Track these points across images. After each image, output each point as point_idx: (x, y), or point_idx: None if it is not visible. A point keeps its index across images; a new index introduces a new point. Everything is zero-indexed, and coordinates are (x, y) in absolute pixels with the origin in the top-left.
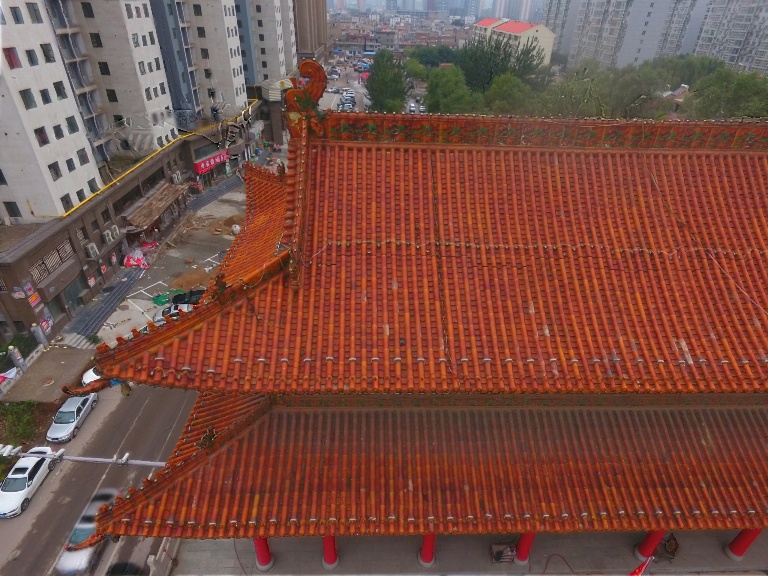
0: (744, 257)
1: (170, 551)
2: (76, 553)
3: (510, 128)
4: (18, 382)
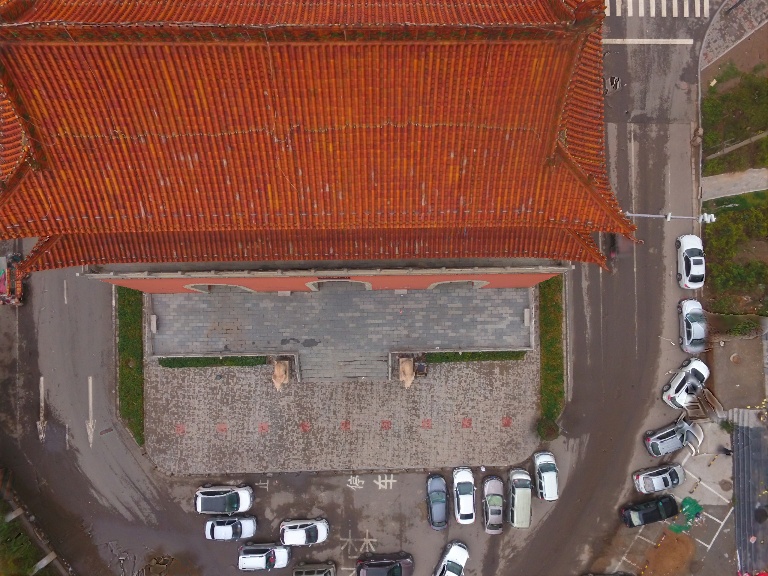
0: (236, 3)
1: None
2: None
3: None
4: (762, 356)
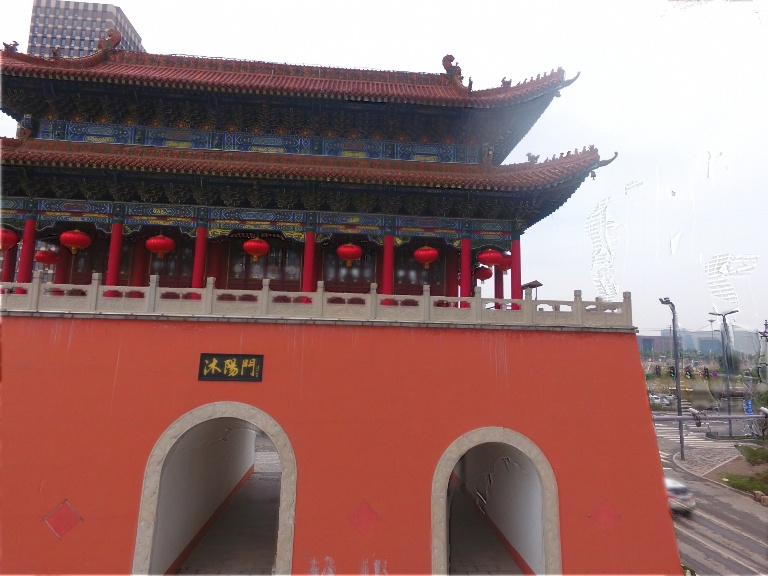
0: None
1: None
2: (761, 550)
3: None
4: None
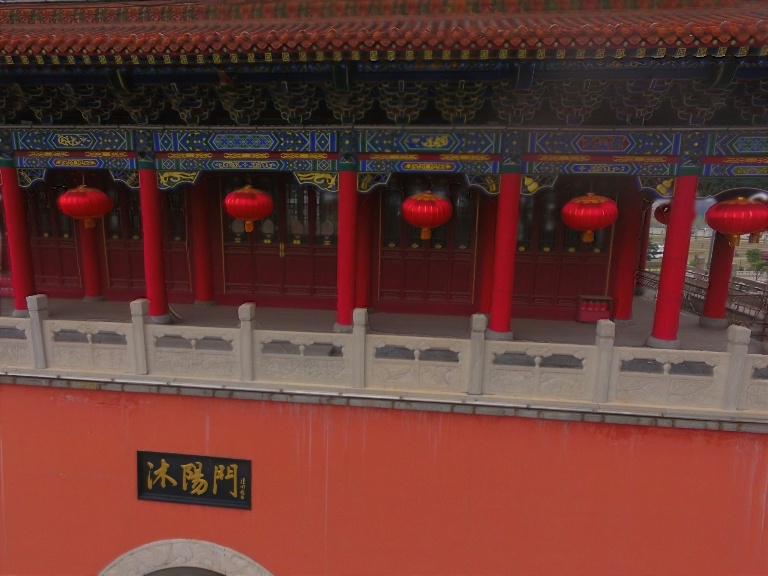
0: None
1: (706, 284)
2: None
3: None
4: None
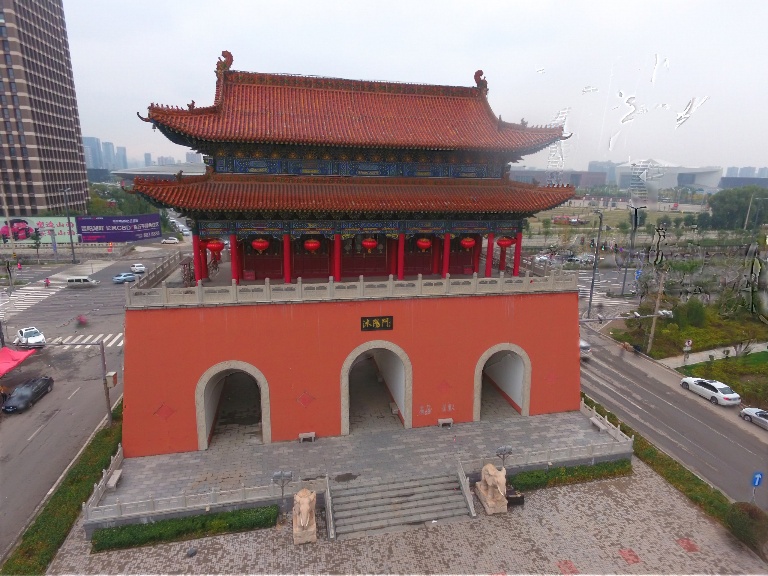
0: None
1: None
2: (619, 379)
3: (411, 88)
4: None
